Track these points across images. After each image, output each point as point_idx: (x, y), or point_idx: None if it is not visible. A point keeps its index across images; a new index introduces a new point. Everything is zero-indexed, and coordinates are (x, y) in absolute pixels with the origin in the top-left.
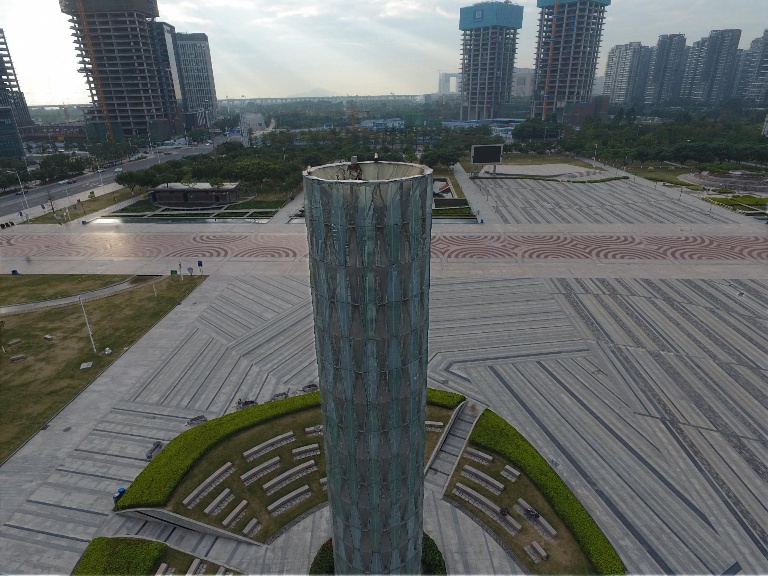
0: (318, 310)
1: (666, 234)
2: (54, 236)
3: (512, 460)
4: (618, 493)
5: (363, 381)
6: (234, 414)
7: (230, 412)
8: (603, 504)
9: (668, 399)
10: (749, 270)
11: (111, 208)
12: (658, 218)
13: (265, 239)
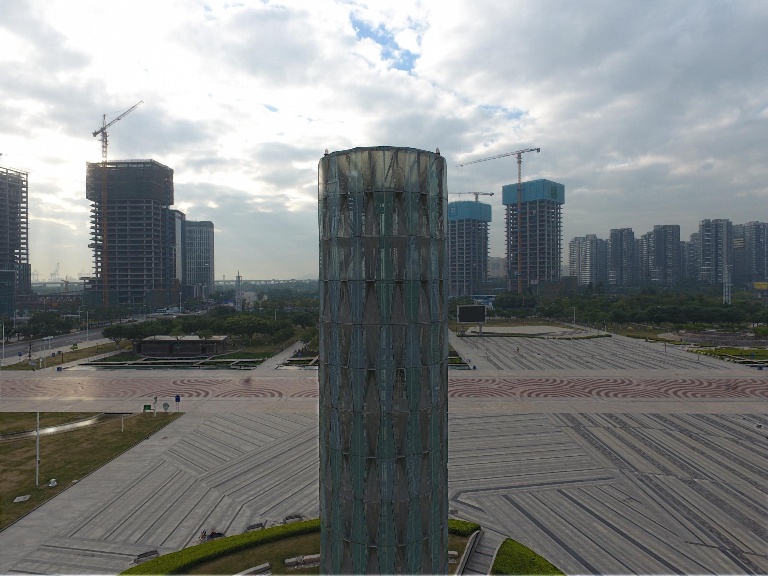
0: (326, 304)
1: (662, 377)
2: (23, 380)
3: None
4: None
5: (376, 381)
6: (196, 546)
7: None
8: None
9: (720, 527)
10: (758, 406)
11: (91, 357)
12: (650, 365)
13: (250, 382)
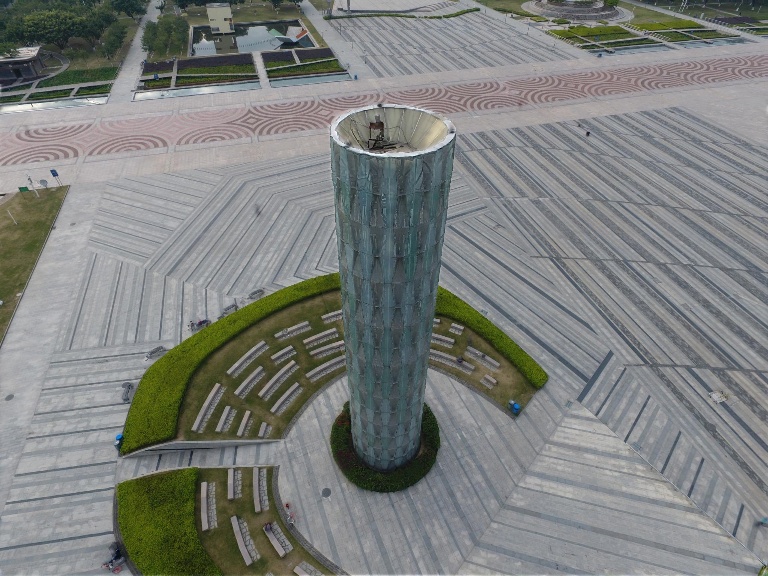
0: (355, 263)
1: (523, 76)
2: None
3: (456, 318)
4: (532, 323)
5: (402, 313)
6: (195, 338)
7: (186, 336)
8: (524, 334)
9: (551, 240)
10: (591, 108)
11: None
12: (514, 58)
13: (116, 126)
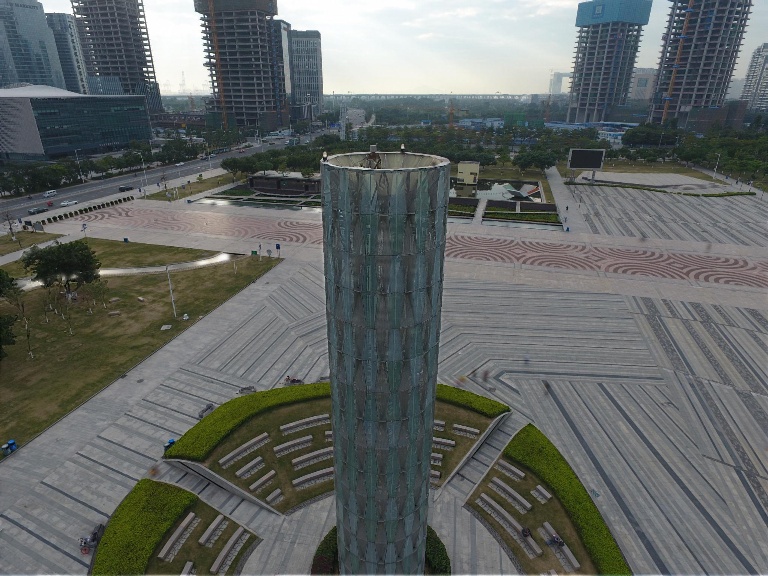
0: (328, 294)
1: None
2: (163, 211)
3: (545, 481)
4: (663, 539)
5: (363, 369)
6: (280, 389)
7: (278, 387)
8: (642, 547)
9: (750, 447)
10: None
11: (213, 190)
12: None
13: None
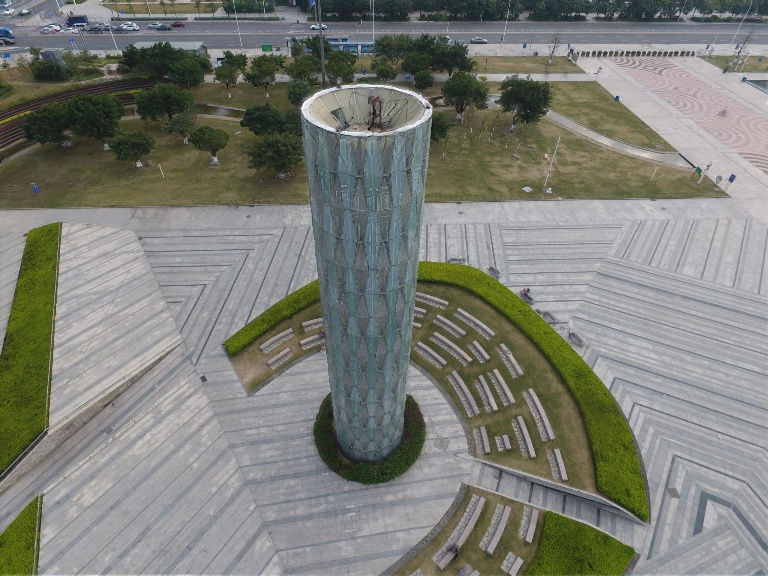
0: None
1: None
2: (698, 81)
3: (530, 567)
4: None
5: None
6: (505, 290)
7: (514, 289)
8: None
9: None
10: None
11: None
12: None
13: None
